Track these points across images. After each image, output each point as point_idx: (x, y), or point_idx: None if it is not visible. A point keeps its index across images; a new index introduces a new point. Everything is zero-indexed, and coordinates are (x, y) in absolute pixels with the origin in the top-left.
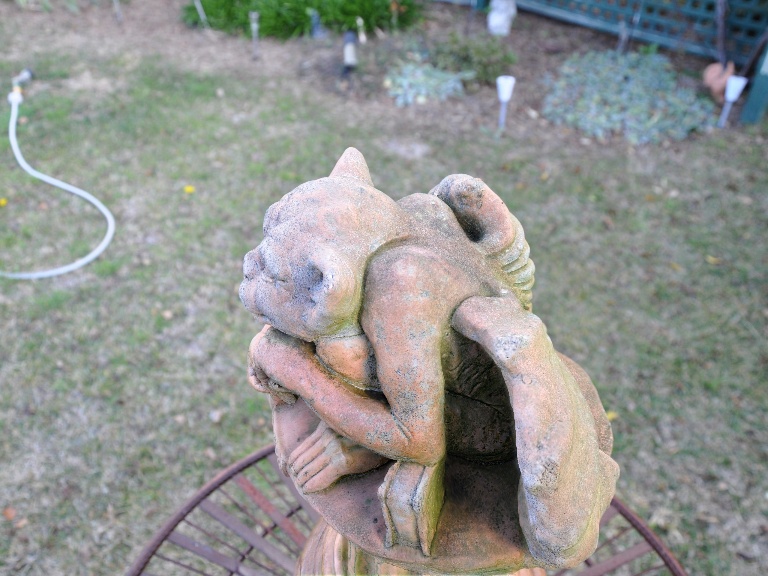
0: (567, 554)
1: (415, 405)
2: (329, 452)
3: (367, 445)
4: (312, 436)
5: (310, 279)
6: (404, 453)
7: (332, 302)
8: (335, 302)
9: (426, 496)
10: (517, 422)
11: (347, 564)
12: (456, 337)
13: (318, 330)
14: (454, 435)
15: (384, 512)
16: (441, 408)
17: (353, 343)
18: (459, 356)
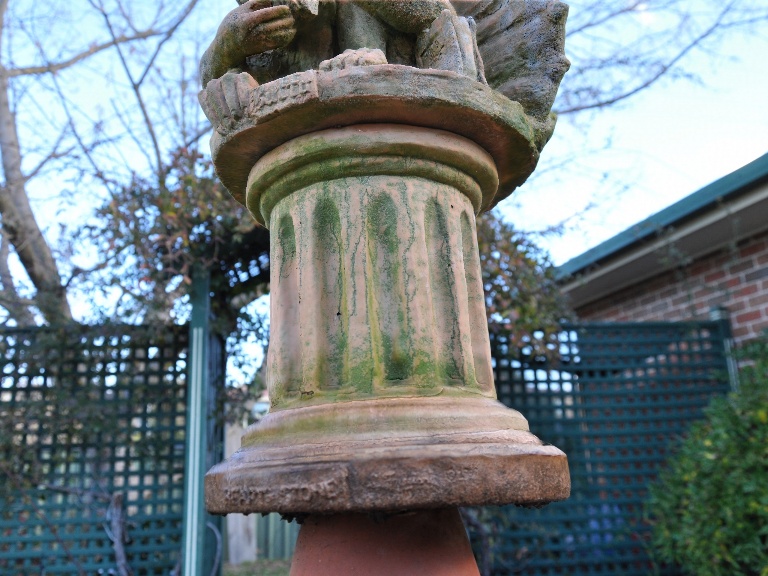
0: None
1: None
2: (363, 49)
3: None
4: None
5: None
6: None
7: None
8: None
9: None
10: None
11: (329, 384)
12: None
13: None
14: None
15: (453, 29)
16: None
17: None
18: None
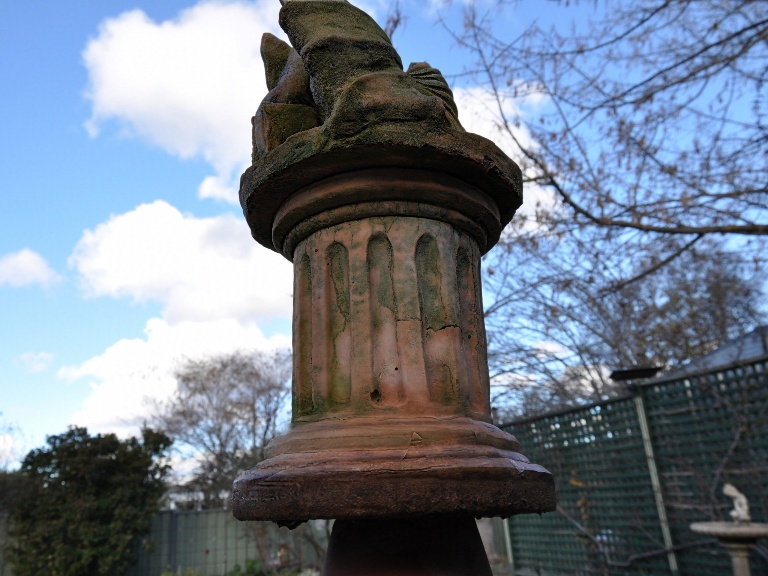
0: (300, 33)
1: None
2: None
3: None
4: None
5: None
6: None
7: (263, 41)
8: (265, 40)
9: (274, 108)
10: None
11: None
12: None
13: None
14: None
15: None
16: (303, 73)
17: None
18: None
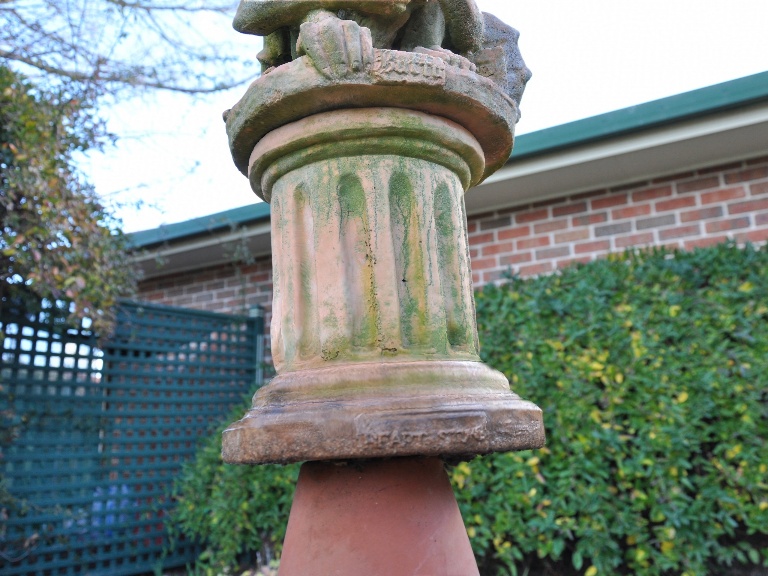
0: None
1: None
2: None
3: None
4: (431, 50)
5: None
6: None
7: None
8: None
9: None
10: (492, 15)
11: None
12: None
13: None
14: None
15: None
16: None
17: None
18: None
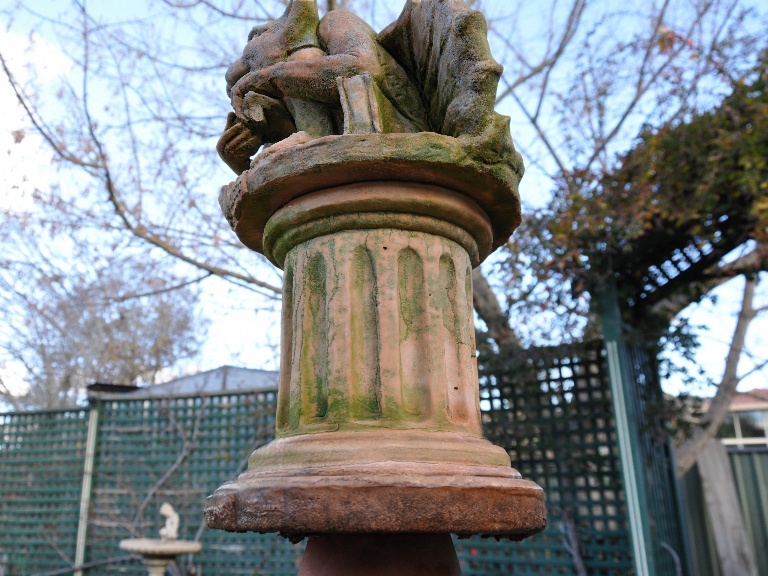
0: (479, 46)
1: (359, 42)
2: None
3: (326, 64)
4: None
5: (285, 21)
6: (354, 63)
7: None
8: None
9: None
10: None
11: None
12: (381, 48)
13: (291, 27)
14: (389, 117)
15: (342, 93)
16: None
17: (313, 49)
18: (384, 58)
